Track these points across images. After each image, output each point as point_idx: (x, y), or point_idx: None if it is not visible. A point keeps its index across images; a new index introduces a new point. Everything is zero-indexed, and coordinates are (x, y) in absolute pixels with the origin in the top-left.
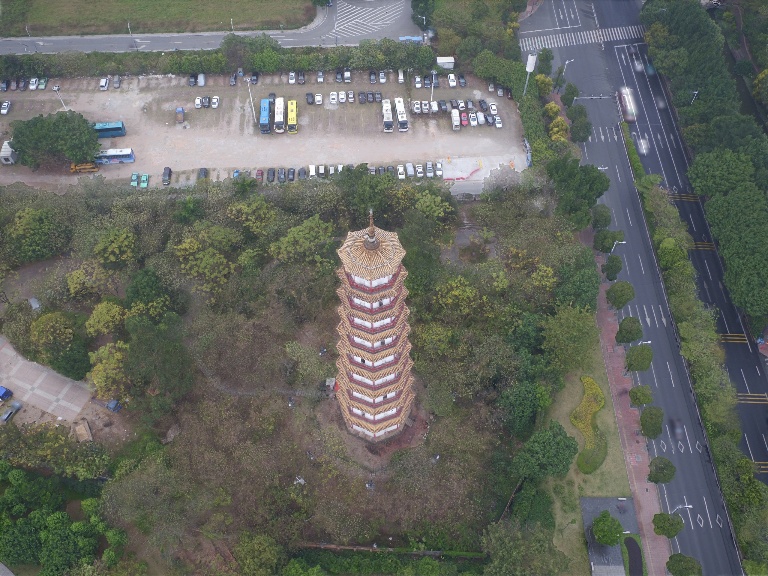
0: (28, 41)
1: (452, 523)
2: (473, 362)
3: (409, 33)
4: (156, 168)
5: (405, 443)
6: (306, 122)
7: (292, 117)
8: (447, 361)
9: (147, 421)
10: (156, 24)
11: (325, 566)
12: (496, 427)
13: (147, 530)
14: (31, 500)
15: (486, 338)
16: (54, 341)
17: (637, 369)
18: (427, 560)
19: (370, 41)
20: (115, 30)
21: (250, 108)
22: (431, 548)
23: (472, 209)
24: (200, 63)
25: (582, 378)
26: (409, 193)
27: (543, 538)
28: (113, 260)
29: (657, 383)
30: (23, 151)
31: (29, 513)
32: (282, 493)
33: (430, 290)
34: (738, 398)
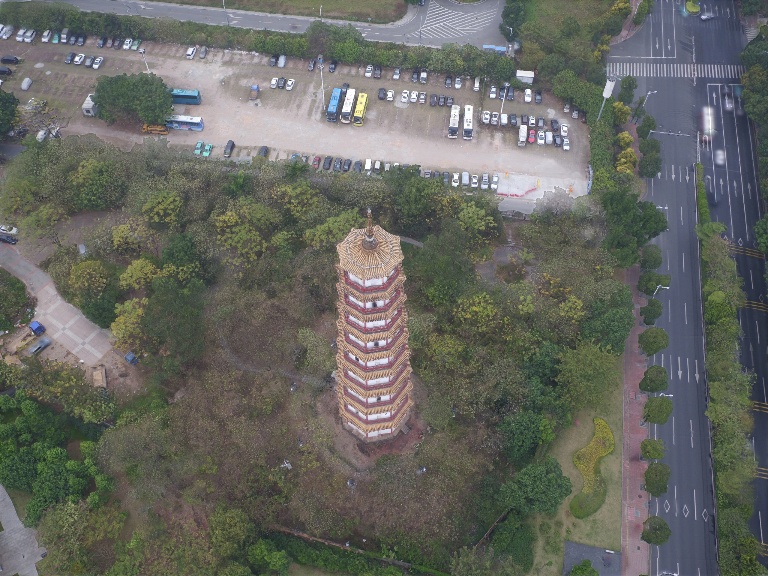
0: (132, 3)
1: (426, 538)
2: (480, 381)
3: (495, 42)
4: (221, 140)
5: (396, 449)
6: (373, 116)
7: (359, 109)
8: (455, 375)
9: (156, 379)
10: (251, 2)
11: (294, 553)
12: (491, 451)
13: (133, 482)
14: (37, 432)
15: (499, 360)
16: (89, 287)
17: (654, 421)
18: (391, 569)
19: (453, 45)
20: (212, 3)
21: (322, 95)
22: (402, 559)
23: (519, 228)
24: (283, 45)
25: (595, 419)
26: (457, 202)
27: (511, 573)
28: (156, 220)
29: (675, 440)
30: (102, 105)
31: (34, 443)
32: (266, 473)
33: (455, 302)
34: (759, 473)
